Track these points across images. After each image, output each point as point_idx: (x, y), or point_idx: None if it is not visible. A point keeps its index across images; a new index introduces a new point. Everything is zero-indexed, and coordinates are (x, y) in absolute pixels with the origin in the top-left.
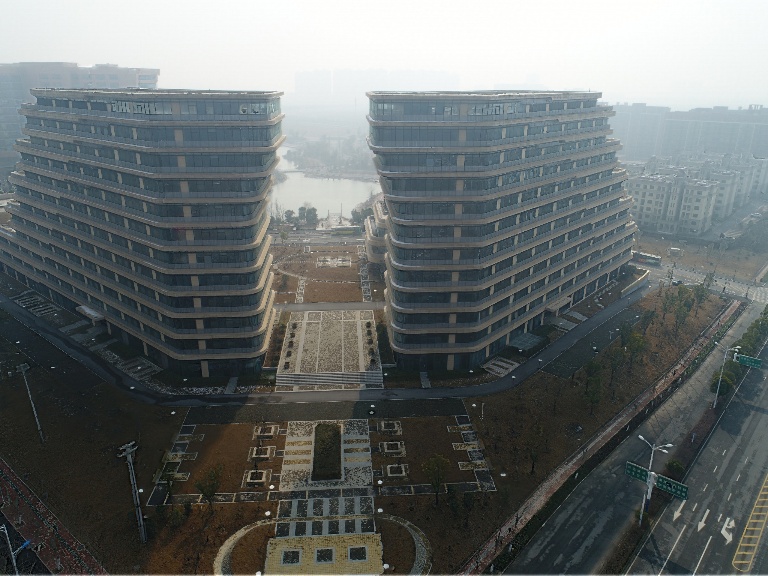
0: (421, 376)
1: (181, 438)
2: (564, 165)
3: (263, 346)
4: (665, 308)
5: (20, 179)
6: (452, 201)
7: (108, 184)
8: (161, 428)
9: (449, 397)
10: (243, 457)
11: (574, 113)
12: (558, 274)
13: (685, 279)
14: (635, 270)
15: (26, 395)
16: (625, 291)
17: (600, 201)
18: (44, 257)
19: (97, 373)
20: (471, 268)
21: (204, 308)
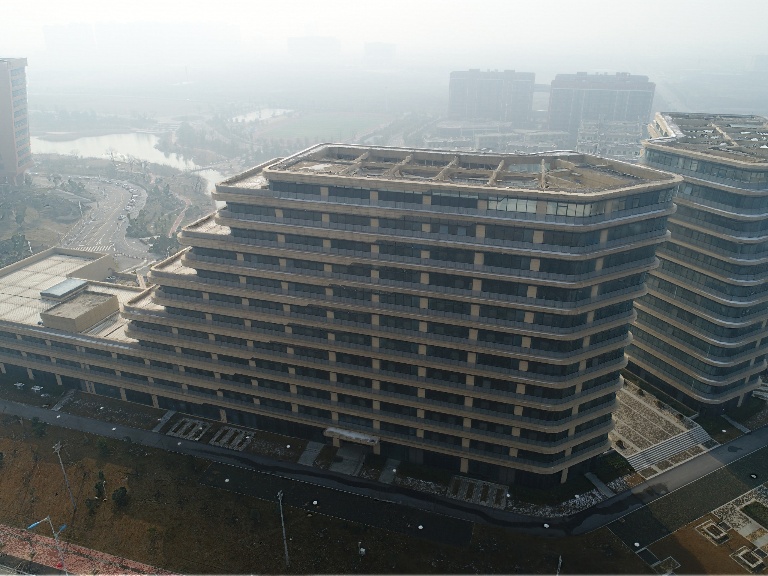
0: None
1: (659, 570)
2: None
3: None
4: None
5: (183, 280)
6: None
7: (445, 291)
8: (625, 565)
9: None
10: (743, 570)
11: None
12: None
13: None
14: None
15: (427, 575)
16: None
17: None
18: (230, 374)
19: (446, 514)
20: None
21: (580, 413)
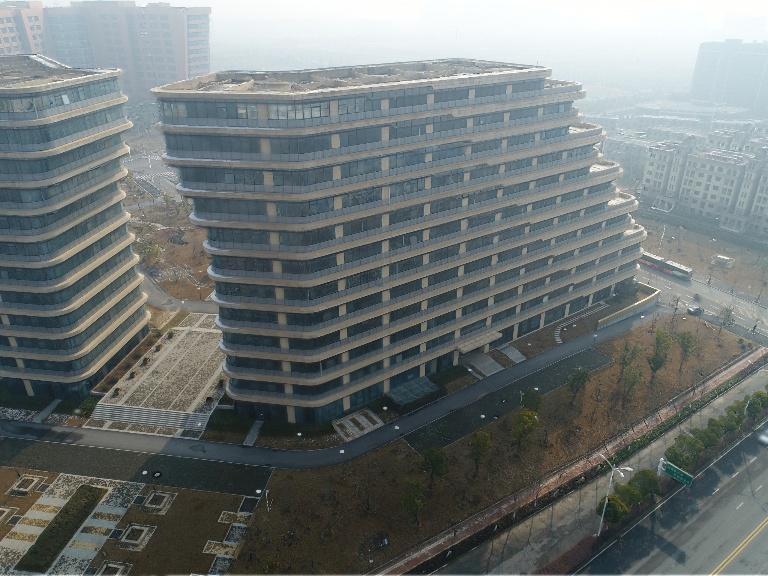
0: (253, 427)
1: None
2: (478, 171)
3: (90, 369)
4: (623, 361)
5: None
6: (262, 229)
7: None
8: None
9: (260, 465)
10: None
11: (492, 102)
12: (482, 304)
13: (711, 305)
14: (638, 289)
15: None
16: (606, 320)
17: (560, 210)
18: None
19: None
20: (297, 311)
21: (13, 326)
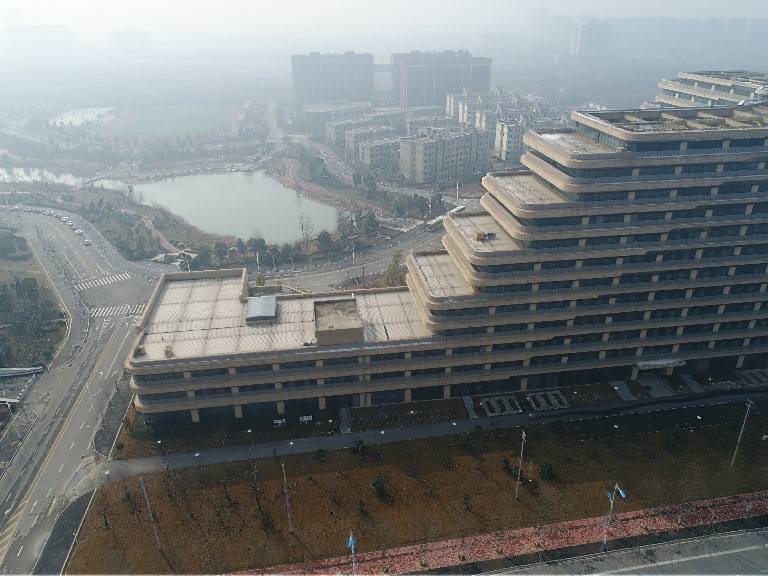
0: None
1: None
2: None
3: None
4: None
5: (518, 255)
6: None
7: (764, 217)
8: None
9: None
10: None
11: None
12: None
13: None
14: None
15: None
16: None
17: None
18: (548, 339)
19: (766, 397)
20: None
21: None
